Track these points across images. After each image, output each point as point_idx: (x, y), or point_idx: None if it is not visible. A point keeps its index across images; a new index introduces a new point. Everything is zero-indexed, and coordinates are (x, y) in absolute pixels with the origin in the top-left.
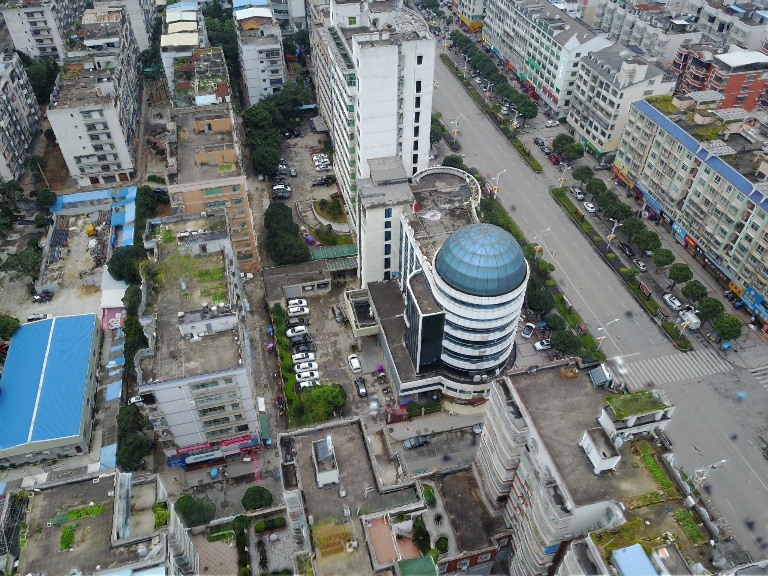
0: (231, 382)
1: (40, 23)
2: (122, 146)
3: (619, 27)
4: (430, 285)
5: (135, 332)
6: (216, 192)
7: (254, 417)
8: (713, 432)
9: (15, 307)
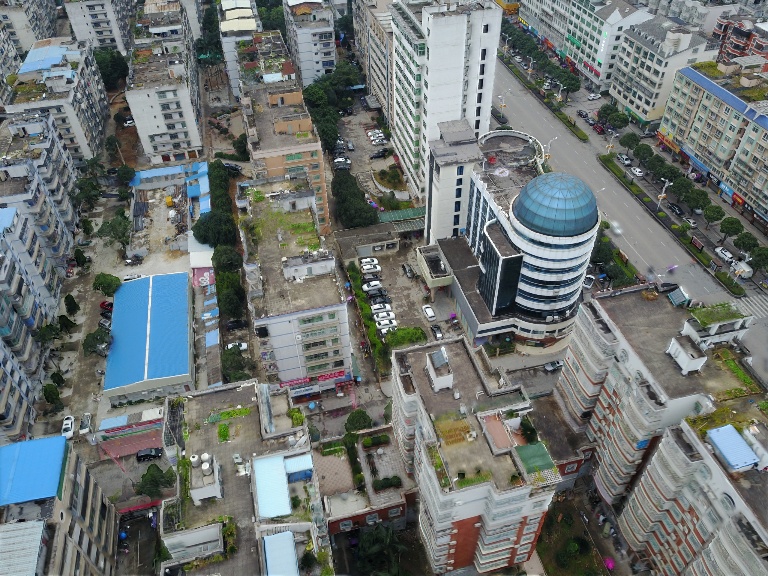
0: (333, 318)
1: (101, 15)
2: (192, 125)
3: (657, 2)
4: (506, 232)
5: (227, 286)
6: (296, 158)
7: (349, 353)
8: None
9: (110, 270)
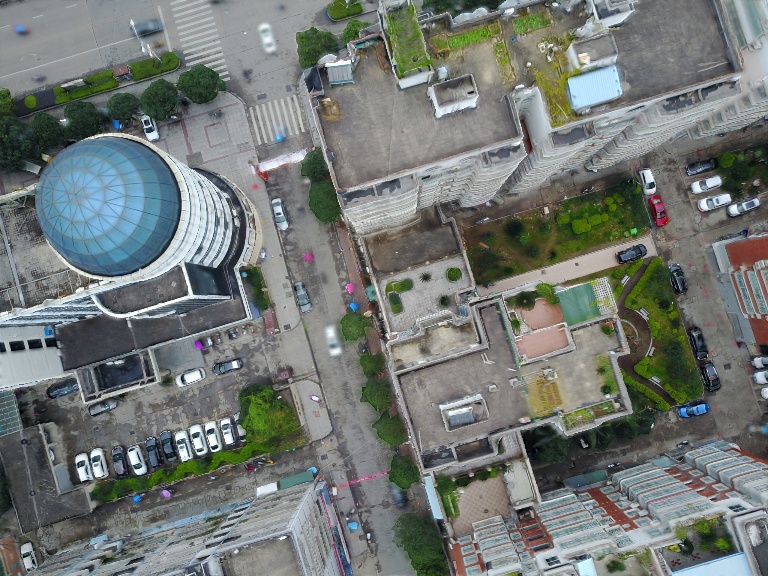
0: None
1: None
2: None
3: None
4: None
5: None
6: None
7: (309, 497)
8: None
9: None
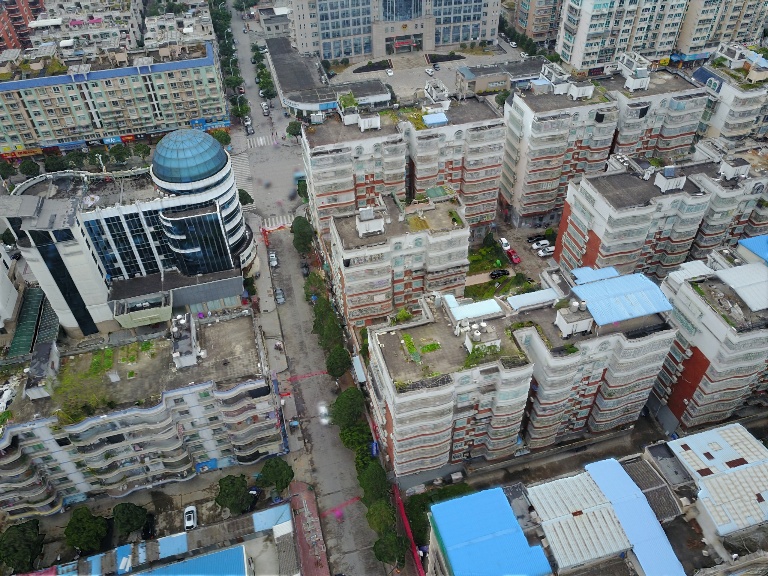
0: None
1: None
2: None
3: None
4: (186, 204)
5: (94, 523)
6: None
7: None
8: (292, 169)
9: None
